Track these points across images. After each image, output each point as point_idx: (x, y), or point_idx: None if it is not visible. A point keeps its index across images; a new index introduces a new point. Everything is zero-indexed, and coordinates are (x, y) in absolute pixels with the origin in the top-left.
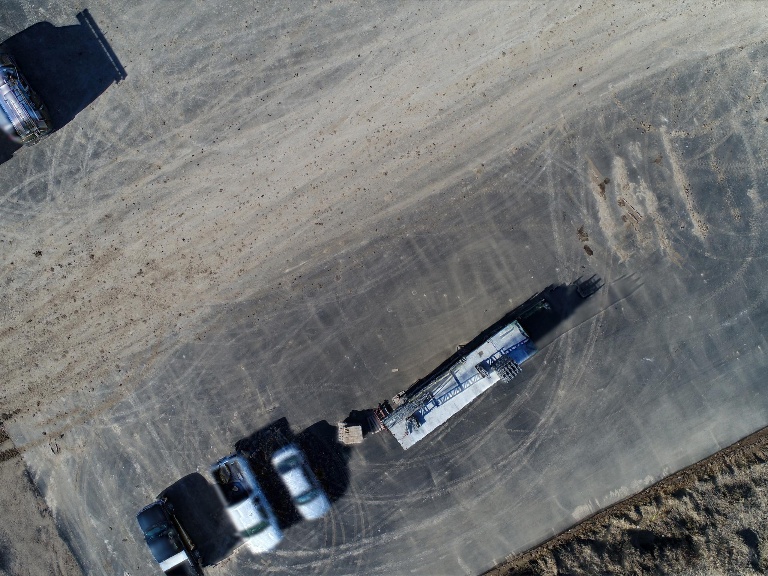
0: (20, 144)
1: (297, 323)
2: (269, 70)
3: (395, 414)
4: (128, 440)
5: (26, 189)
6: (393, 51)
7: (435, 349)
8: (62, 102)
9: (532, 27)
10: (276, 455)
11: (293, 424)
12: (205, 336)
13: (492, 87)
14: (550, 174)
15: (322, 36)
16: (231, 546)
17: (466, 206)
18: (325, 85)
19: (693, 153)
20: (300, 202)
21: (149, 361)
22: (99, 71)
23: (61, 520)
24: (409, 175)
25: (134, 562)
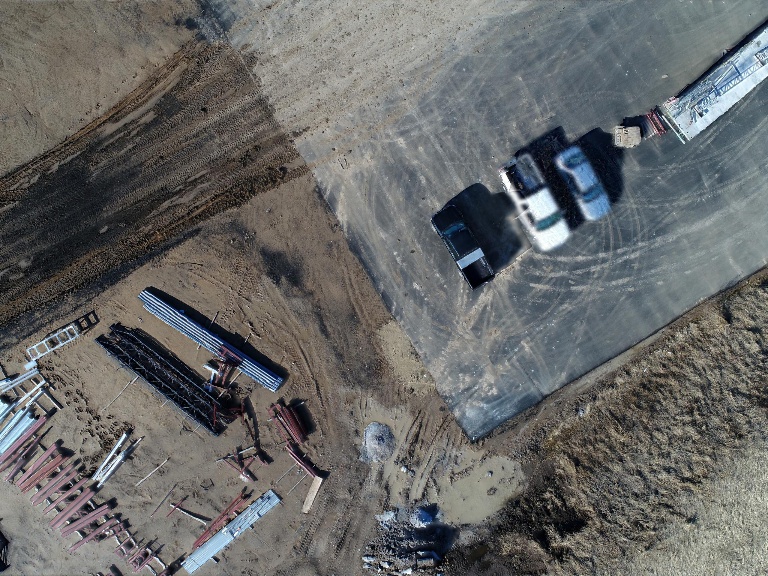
0: None
1: (571, 33)
2: None
3: (690, 93)
4: (413, 153)
5: None
6: None
7: (702, 54)
8: None
9: None
10: (554, 163)
11: (569, 132)
12: (483, 49)
13: None
14: None
15: None
16: (514, 254)
17: None
18: None
19: None
20: None
21: (431, 75)
22: None
23: (352, 234)
24: None
25: (422, 273)
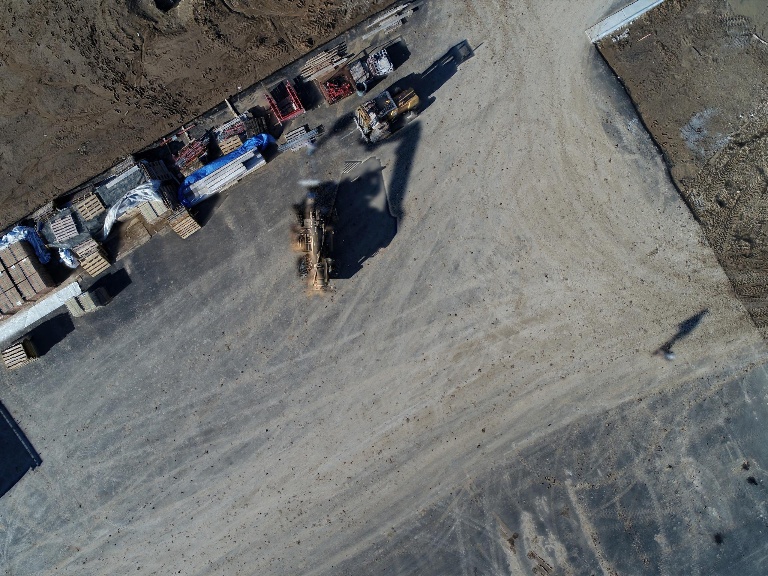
0: None
1: None
2: (180, 449)
3: None
4: None
5: None
6: (299, 424)
7: None
8: None
9: (434, 392)
10: None
11: None
12: None
13: (398, 453)
14: (459, 533)
15: (230, 413)
16: None
17: (379, 569)
18: (235, 460)
19: (599, 503)
20: (216, 575)
21: None
22: (15, 459)
23: None
24: (321, 543)
25: None
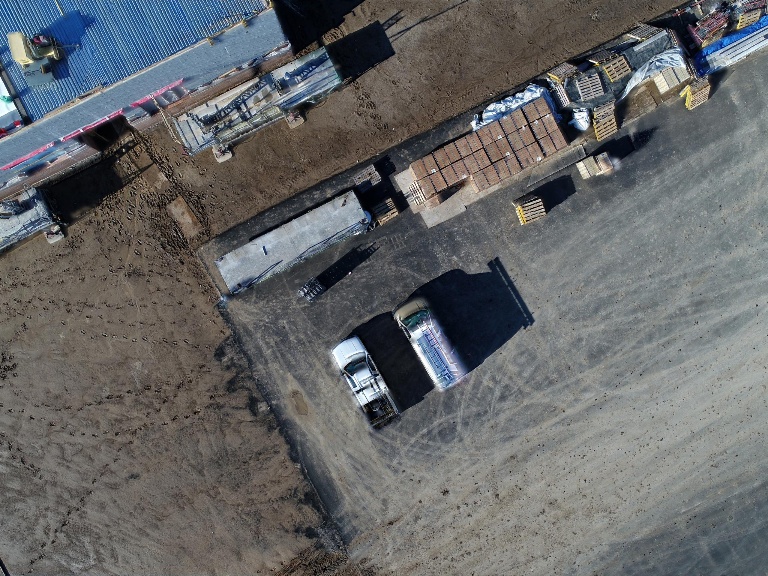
0: (431, 387)
1: (690, 561)
2: (670, 318)
3: None
4: None
5: (436, 430)
6: None
7: None
8: (472, 347)
9: None
10: None
11: None
12: (602, 573)
13: None
14: None
15: (722, 286)
16: None
17: None
18: (724, 333)
19: None
20: (697, 445)
21: None
22: (508, 317)
23: None
24: None
25: None
